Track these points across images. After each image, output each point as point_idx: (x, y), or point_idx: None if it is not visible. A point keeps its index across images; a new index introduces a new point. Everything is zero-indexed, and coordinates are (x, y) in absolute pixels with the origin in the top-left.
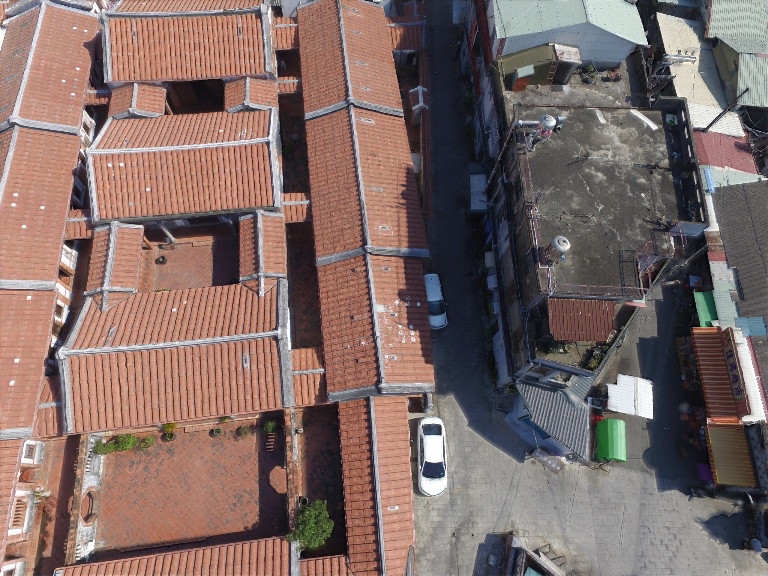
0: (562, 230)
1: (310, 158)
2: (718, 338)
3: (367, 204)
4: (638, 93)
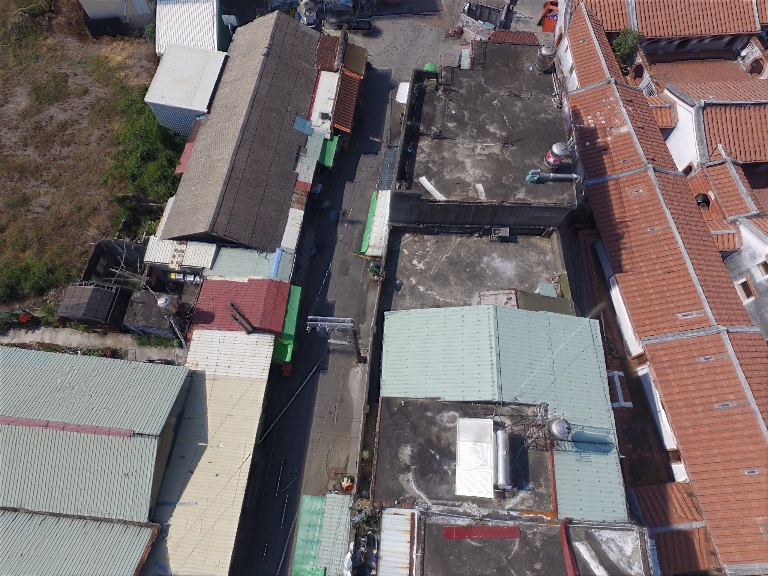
0: (531, 87)
1: (730, 277)
2: (336, 119)
3: (661, 209)
4: (383, 296)
